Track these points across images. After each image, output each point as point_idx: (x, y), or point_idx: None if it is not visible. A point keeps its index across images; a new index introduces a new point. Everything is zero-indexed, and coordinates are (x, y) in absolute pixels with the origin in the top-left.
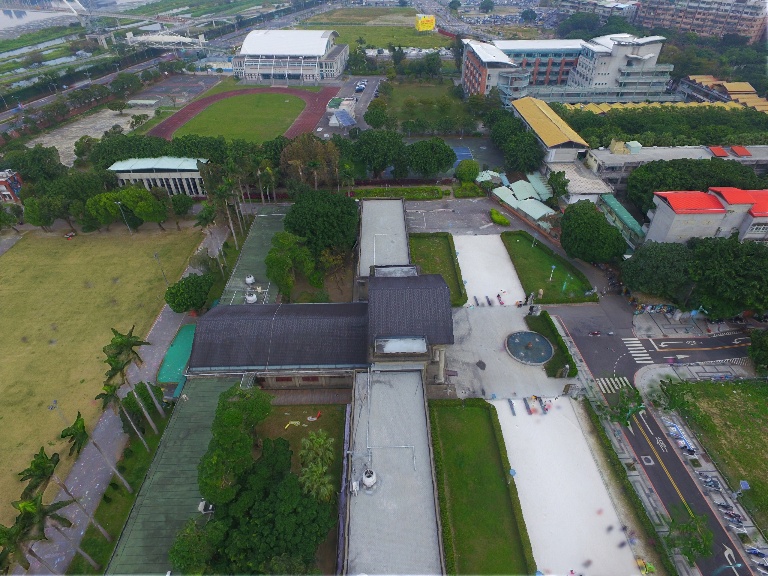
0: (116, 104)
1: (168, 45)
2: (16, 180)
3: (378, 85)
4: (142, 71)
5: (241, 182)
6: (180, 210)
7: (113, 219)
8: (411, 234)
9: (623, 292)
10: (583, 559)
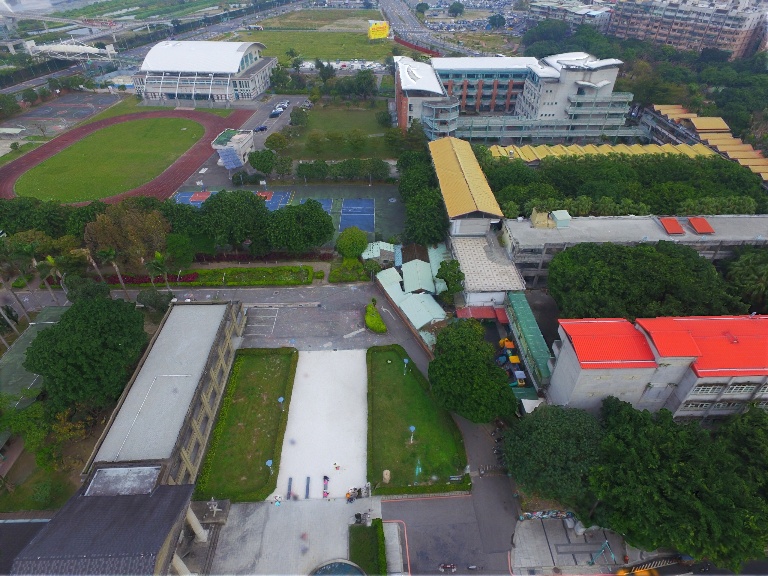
0: None
1: (73, 56)
2: None
3: None
4: (35, 87)
5: None
6: None
7: None
8: (242, 351)
9: (510, 472)
10: None
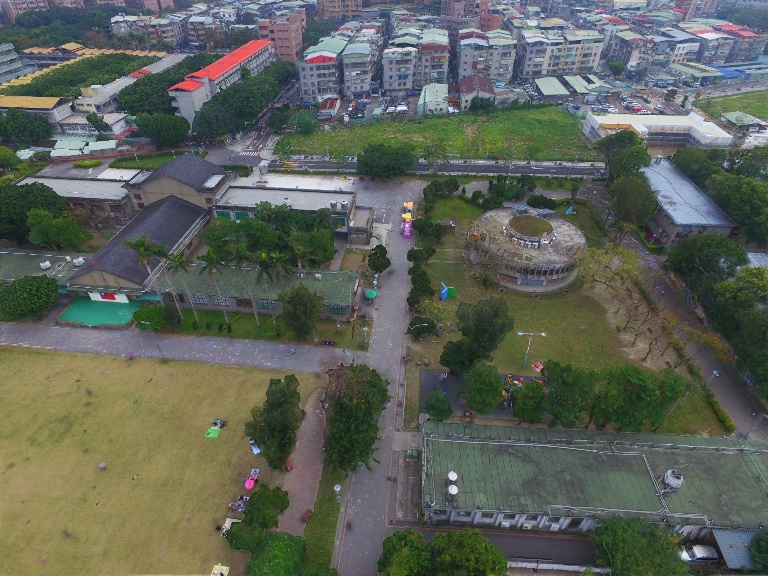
0: None
1: None
2: None
3: None
4: None
5: None
6: None
7: None
8: None
9: (209, 145)
10: (335, 189)
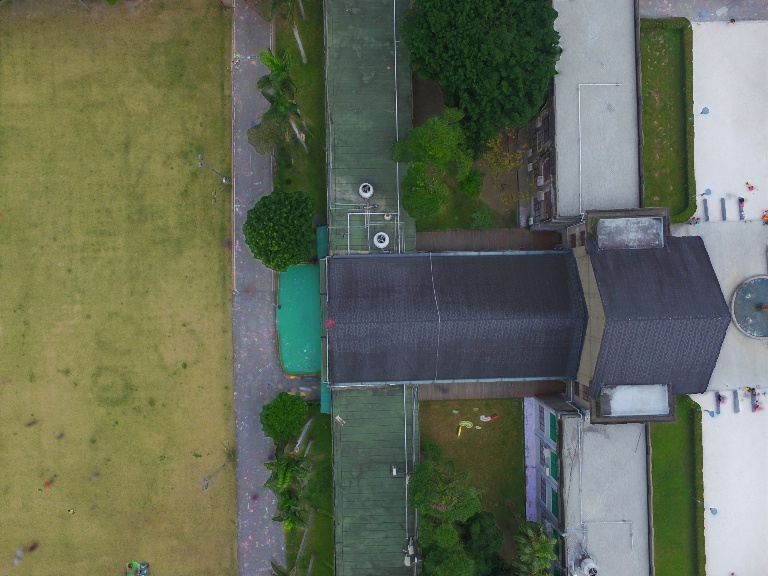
0: None
1: None
2: None
3: None
4: None
5: None
6: None
7: None
8: None
9: None
10: (745, 564)
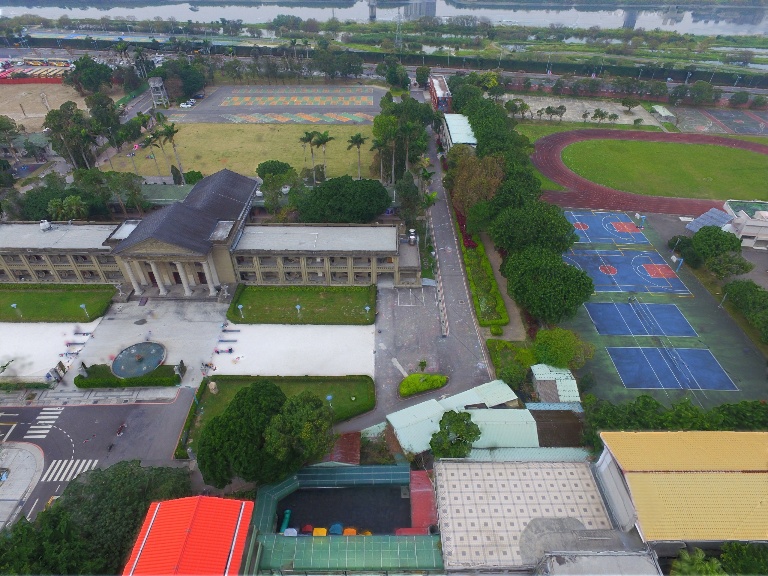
0: (628, 99)
1: None
2: (446, 101)
3: None
4: None
5: None
6: None
7: None
8: (371, 287)
9: None
10: None
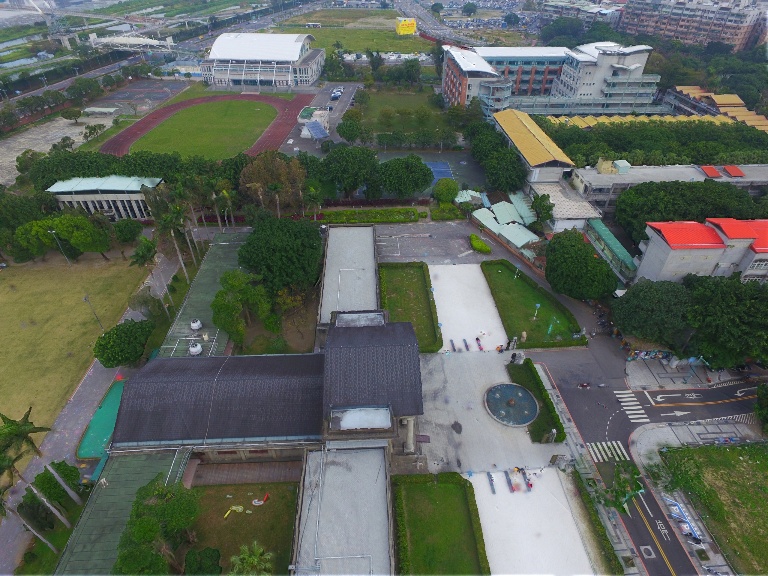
0: (70, 112)
1: (134, 47)
2: None
3: (355, 92)
4: None
5: (197, 205)
6: (126, 237)
7: (48, 249)
8: (383, 264)
9: (614, 334)
10: None
